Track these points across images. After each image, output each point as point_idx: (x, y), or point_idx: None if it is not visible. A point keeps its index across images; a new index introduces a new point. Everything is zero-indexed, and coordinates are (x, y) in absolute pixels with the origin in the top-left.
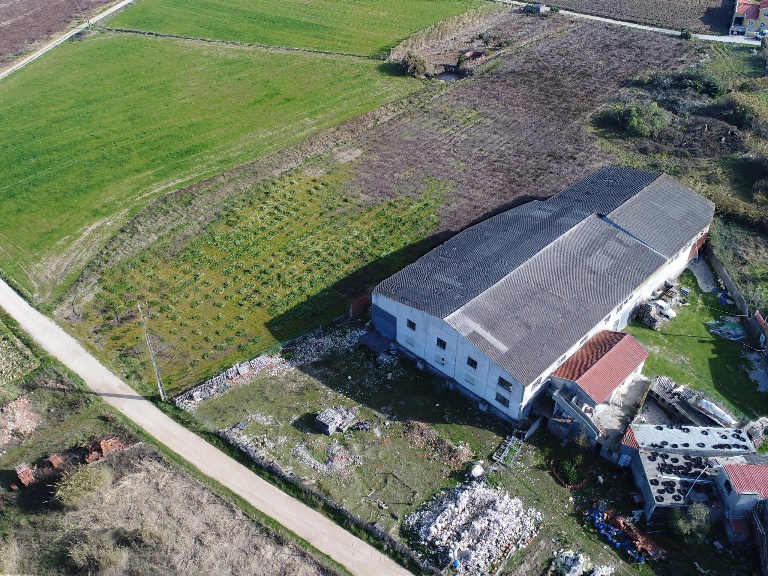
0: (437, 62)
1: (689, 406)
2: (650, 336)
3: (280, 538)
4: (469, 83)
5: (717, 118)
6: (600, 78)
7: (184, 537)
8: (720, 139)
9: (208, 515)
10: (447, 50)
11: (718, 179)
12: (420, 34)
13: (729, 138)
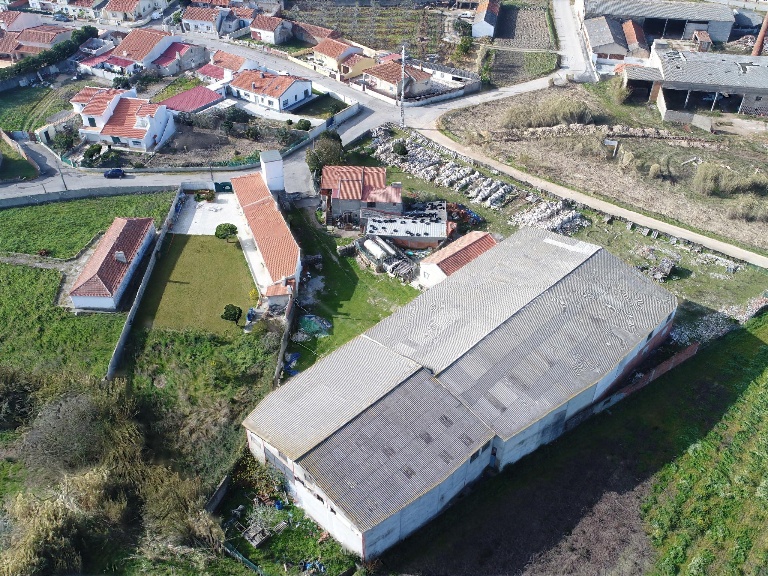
0: None
1: None
2: None
3: (662, 215)
4: None
5: None
6: None
7: (718, 219)
8: None
9: (713, 227)
10: None
11: None
12: None
13: None
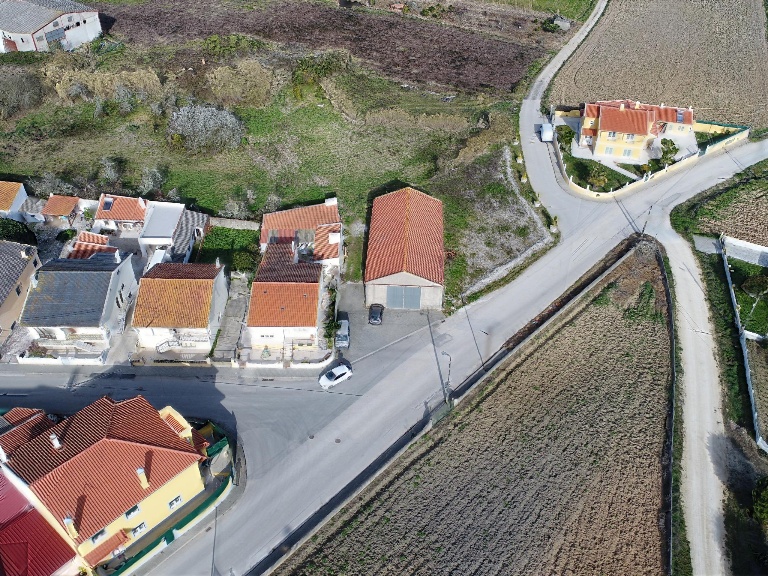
0: None
1: None
2: None
3: None
4: None
5: None
6: None
7: None
8: None
9: None
10: None
11: None
12: None
13: None
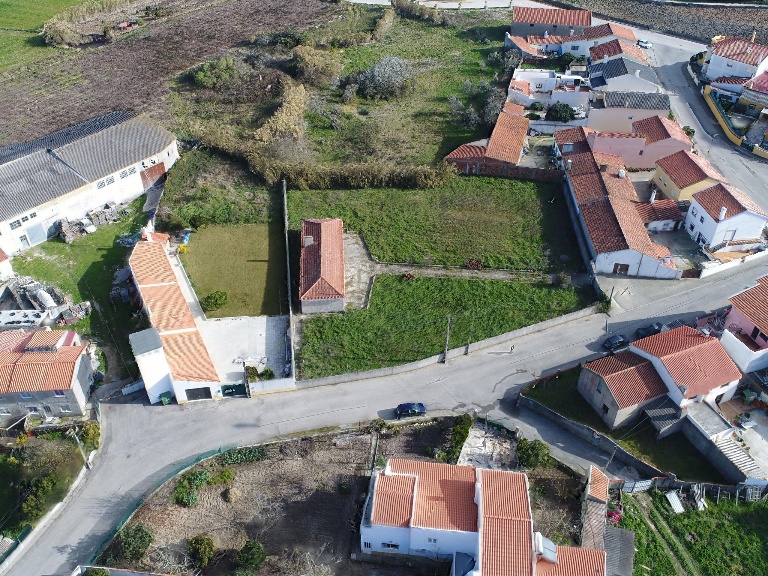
0: (89, 33)
1: (25, 296)
2: (58, 248)
3: None
4: (100, 50)
5: (284, 69)
6: (222, 40)
7: None
8: (266, 87)
9: None
10: (108, 21)
11: (240, 120)
12: (75, 7)
13: (274, 85)
